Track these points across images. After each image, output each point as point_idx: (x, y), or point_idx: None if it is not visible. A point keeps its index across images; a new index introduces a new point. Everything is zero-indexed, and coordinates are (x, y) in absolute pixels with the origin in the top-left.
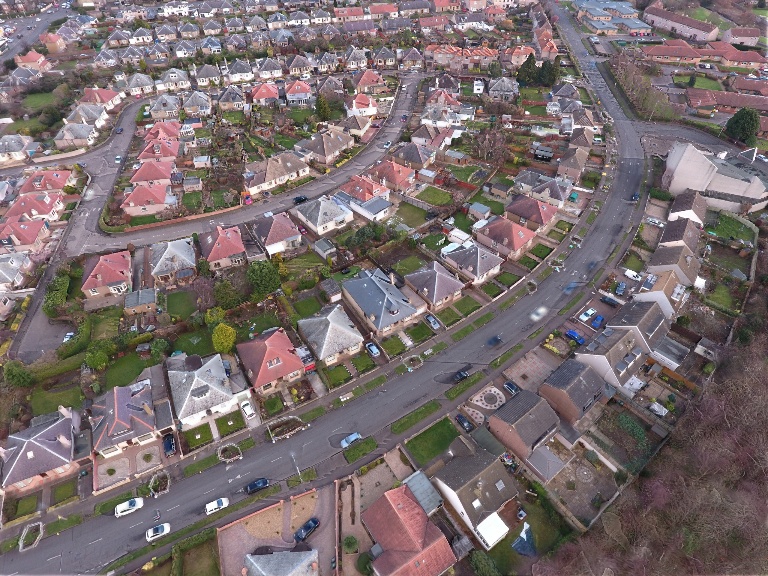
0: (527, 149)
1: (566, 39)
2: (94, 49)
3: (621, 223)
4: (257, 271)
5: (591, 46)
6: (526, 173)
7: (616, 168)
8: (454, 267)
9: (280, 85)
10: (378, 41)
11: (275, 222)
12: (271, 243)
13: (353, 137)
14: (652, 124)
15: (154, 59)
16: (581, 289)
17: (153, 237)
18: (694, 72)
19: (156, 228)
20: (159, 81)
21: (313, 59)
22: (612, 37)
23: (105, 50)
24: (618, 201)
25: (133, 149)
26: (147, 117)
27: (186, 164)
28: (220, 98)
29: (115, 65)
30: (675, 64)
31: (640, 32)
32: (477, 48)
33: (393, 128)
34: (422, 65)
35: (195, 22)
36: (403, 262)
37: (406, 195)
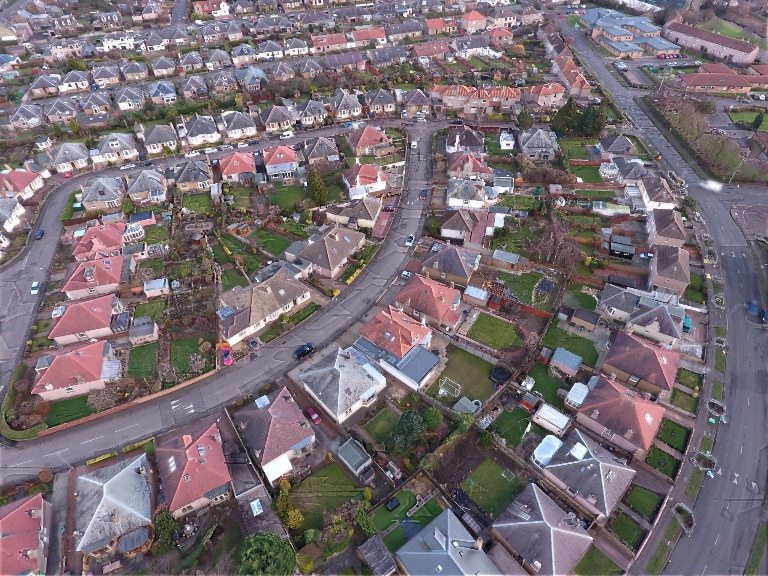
0: (599, 242)
1: (588, 66)
2: (11, 103)
3: (764, 367)
4: (257, 571)
5: (620, 75)
6: (618, 293)
7: (718, 264)
8: (560, 488)
9: (255, 148)
10: (370, 79)
11: (274, 421)
12: (270, 459)
13: (364, 233)
14: (734, 187)
15: (89, 116)
16: (759, 515)
17: (84, 444)
18: (752, 107)
19: (89, 424)
20: (95, 151)
21: (294, 108)
22: (638, 61)
23: (24, 106)
24: (744, 325)
25: (57, 268)
26: (79, 210)
27: (134, 292)
28: (178, 177)
29: (38, 125)
30: (724, 96)
31: (668, 53)
32: (496, 88)
33: (412, 211)
34: (429, 110)
35: (142, 58)
36: (477, 475)
37: (453, 331)
